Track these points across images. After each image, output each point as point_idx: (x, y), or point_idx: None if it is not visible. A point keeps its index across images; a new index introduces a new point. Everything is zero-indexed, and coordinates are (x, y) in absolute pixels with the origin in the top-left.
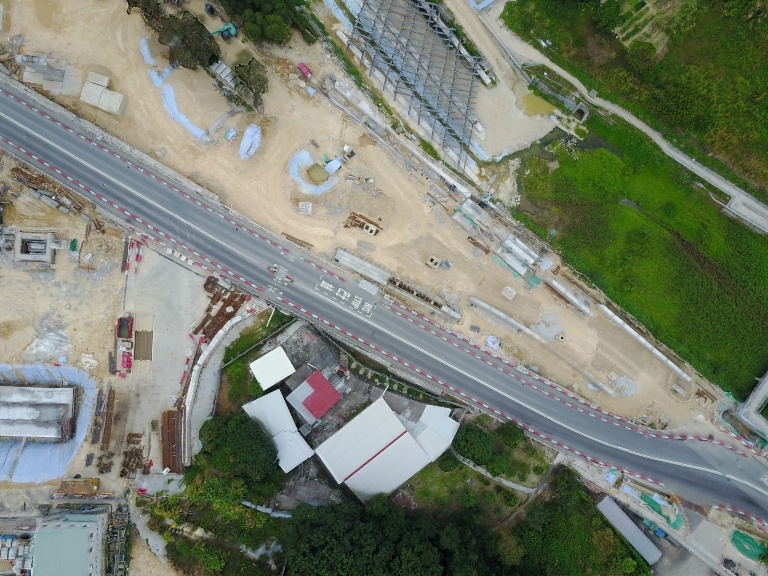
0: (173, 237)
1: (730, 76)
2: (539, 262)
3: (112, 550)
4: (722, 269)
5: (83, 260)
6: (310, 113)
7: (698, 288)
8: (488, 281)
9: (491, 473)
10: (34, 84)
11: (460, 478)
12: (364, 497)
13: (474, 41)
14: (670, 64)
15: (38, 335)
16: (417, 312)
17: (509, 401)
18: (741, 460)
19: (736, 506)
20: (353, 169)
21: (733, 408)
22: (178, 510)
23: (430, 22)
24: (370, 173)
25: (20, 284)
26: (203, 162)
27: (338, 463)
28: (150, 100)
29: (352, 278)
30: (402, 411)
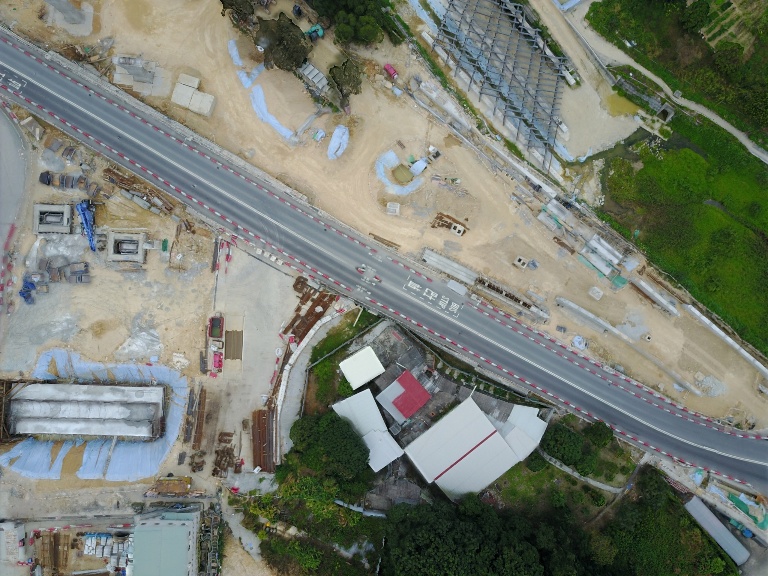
0: (262, 237)
1: None
2: (623, 262)
3: (204, 548)
4: None
5: (174, 260)
6: (396, 114)
7: None
8: (574, 281)
9: (581, 473)
10: (124, 86)
11: (547, 478)
12: (454, 496)
13: (559, 42)
14: (757, 64)
15: (130, 335)
16: (504, 312)
17: (595, 401)
18: None
19: None
20: (438, 170)
21: None
22: (273, 509)
23: (515, 23)
24: (456, 174)
25: (112, 284)
26: (291, 163)
27: (428, 462)
28: (239, 101)
29: (439, 278)
30: (490, 411)
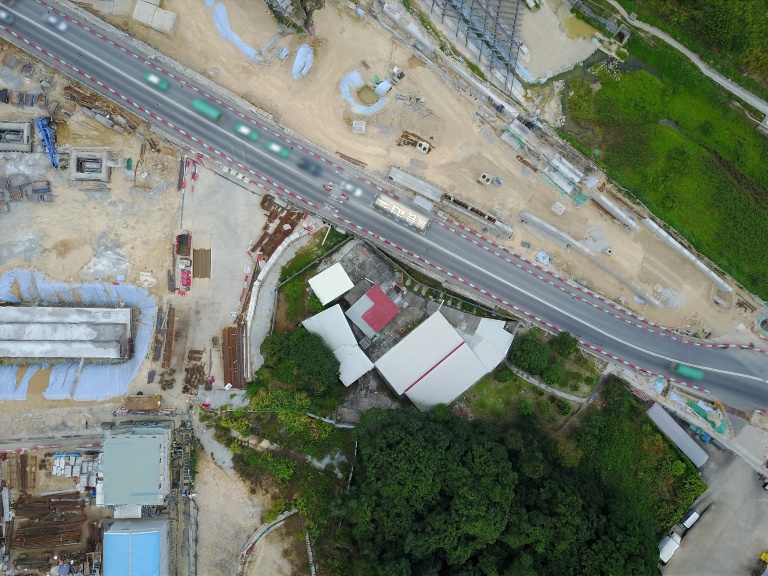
0: (229, 156)
1: None
2: (584, 180)
3: (176, 466)
4: (758, 185)
5: (139, 179)
6: (360, 35)
7: (736, 203)
8: (537, 198)
9: (547, 381)
10: (84, 4)
11: (514, 390)
12: (424, 408)
13: None
14: None
15: (95, 254)
16: (470, 228)
17: (560, 314)
18: None
19: None
20: (403, 90)
21: None
22: (244, 421)
23: None
24: (420, 94)
25: (76, 203)
26: (256, 82)
27: (398, 375)
28: (202, 20)
29: (406, 196)
30: (458, 324)
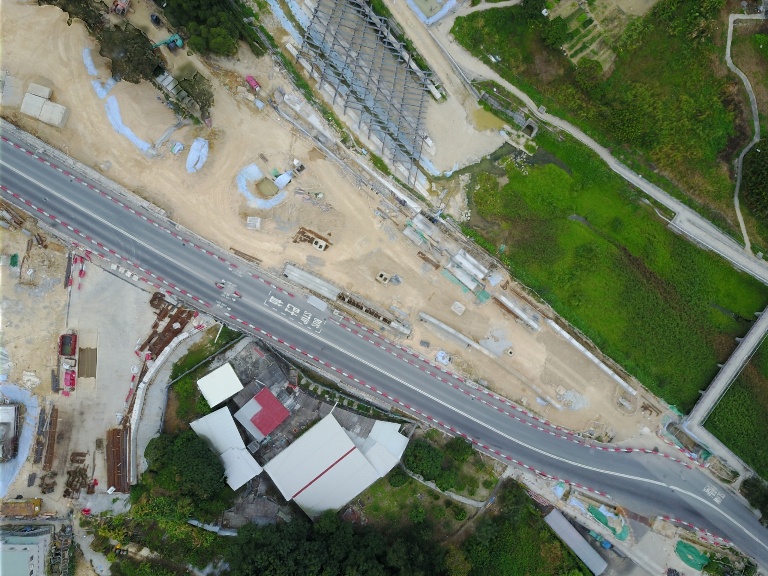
0: (118, 252)
1: (675, 94)
2: (489, 277)
3: (55, 571)
4: (667, 284)
5: (24, 276)
6: (259, 127)
7: (644, 303)
8: (438, 296)
9: (440, 488)
10: None
11: (410, 493)
12: (313, 514)
13: (424, 56)
14: (617, 81)
15: None
16: (367, 327)
17: (459, 415)
18: (685, 471)
19: (680, 516)
20: (303, 183)
21: (677, 420)
22: (122, 530)
23: (380, 36)
24: (320, 188)
25: None
26: (149, 176)
27: (287, 480)
28: (94, 112)
29: (301, 294)
30: (351, 427)
